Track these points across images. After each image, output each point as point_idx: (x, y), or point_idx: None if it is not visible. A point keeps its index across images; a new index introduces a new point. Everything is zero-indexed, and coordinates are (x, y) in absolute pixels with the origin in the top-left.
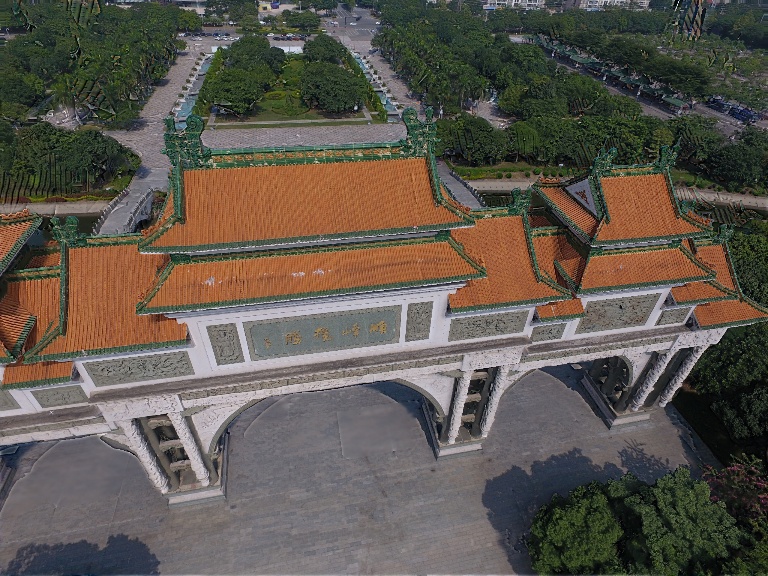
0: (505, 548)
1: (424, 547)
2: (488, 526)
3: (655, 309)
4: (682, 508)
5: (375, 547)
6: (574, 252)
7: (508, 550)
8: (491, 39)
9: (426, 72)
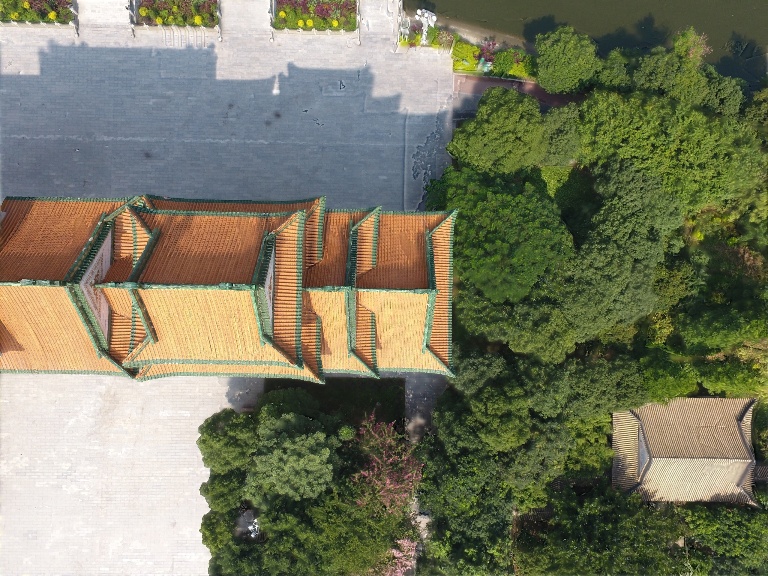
0: (221, 399)
1: (158, 385)
2: (214, 381)
3: None
4: (290, 467)
5: (120, 378)
6: None
7: (222, 401)
8: None
9: None
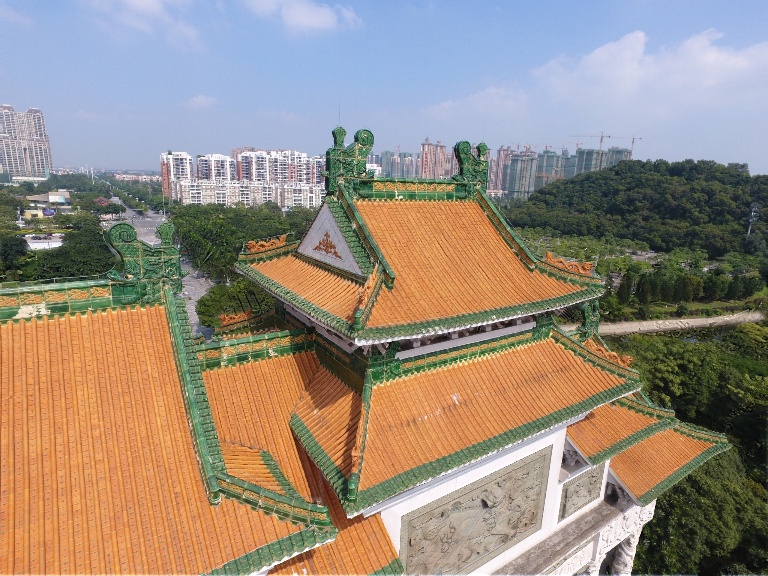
0: None
1: None
2: None
3: (550, 485)
4: None
5: None
6: (337, 384)
7: None
8: (286, 225)
9: (211, 249)
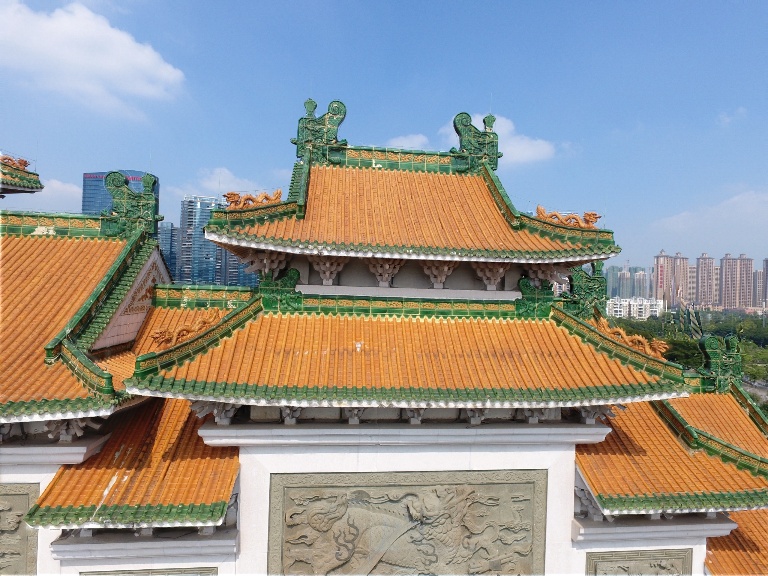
0: None
1: None
2: None
3: (553, 541)
4: None
5: None
6: None
7: None
8: None
9: None
